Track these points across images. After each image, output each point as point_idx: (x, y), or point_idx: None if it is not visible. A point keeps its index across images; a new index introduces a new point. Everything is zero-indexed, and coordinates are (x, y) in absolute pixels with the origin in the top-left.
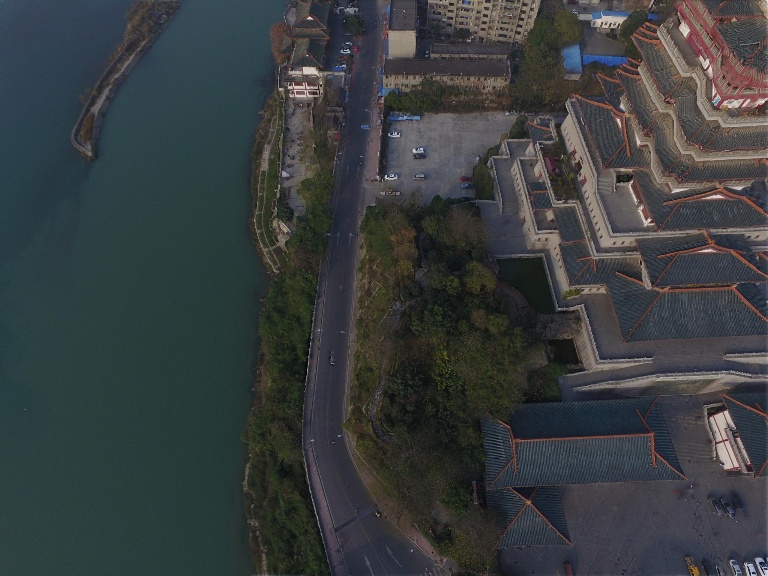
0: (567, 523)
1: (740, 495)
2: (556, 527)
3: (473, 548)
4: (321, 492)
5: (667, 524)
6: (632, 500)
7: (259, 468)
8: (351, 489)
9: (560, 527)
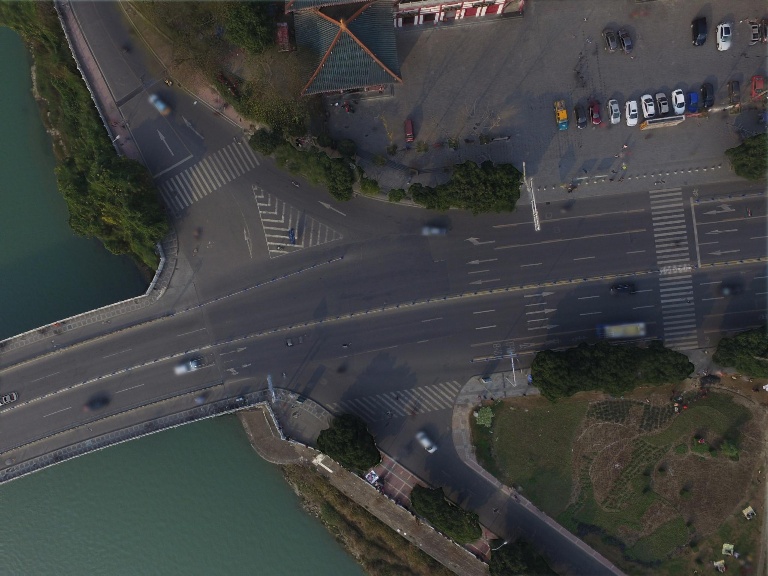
0: (414, 78)
1: (646, 24)
2: (383, 62)
3: (272, 93)
4: (91, 60)
5: (542, 68)
6: (502, 43)
7: (43, 67)
8: (131, 54)
9: (389, 62)
